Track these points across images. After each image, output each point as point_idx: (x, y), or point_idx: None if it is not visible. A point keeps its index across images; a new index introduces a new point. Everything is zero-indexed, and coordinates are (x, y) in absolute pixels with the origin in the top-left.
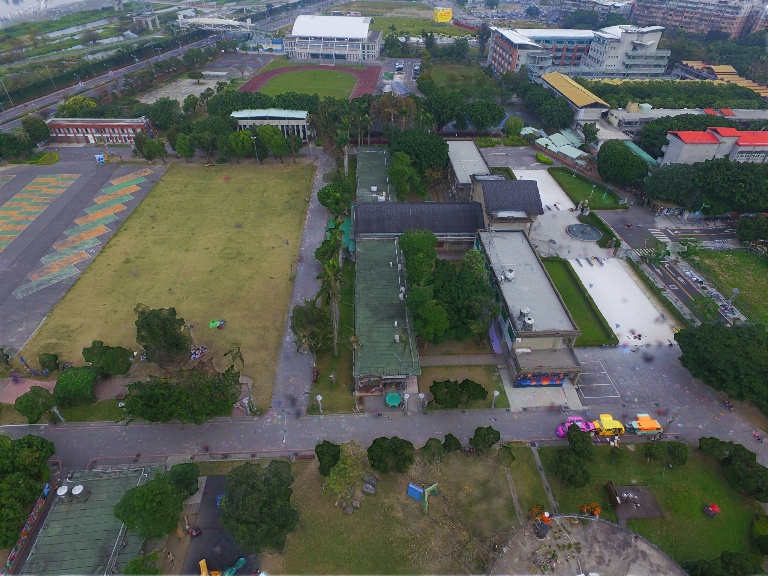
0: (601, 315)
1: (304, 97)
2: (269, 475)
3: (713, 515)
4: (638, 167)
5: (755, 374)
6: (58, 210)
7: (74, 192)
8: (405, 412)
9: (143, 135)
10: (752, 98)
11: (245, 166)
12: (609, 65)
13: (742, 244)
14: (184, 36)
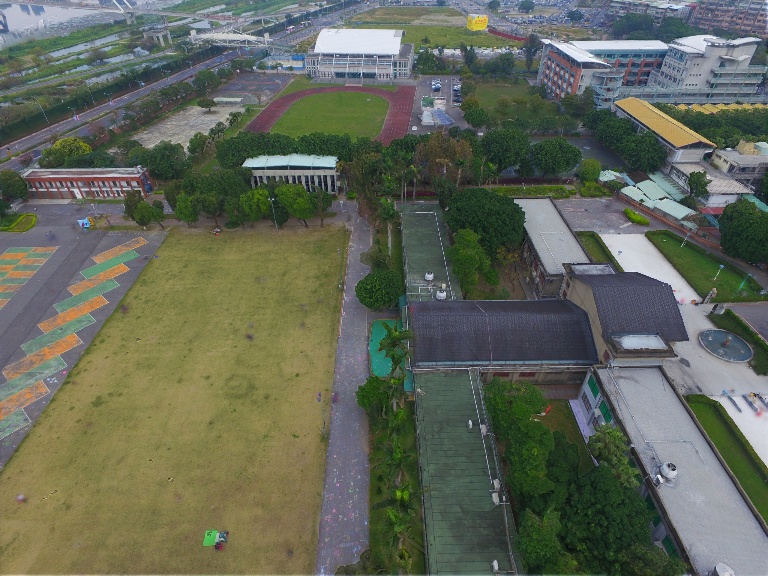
0: None
1: (333, 139)
2: None
3: None
4: None
5: None
6: (20, 307)
7: (46, 276)
8: None
9: (136, 194)
10: None
11: (261, 232)
12: (690, 84)
13: None
14: (196, 54)
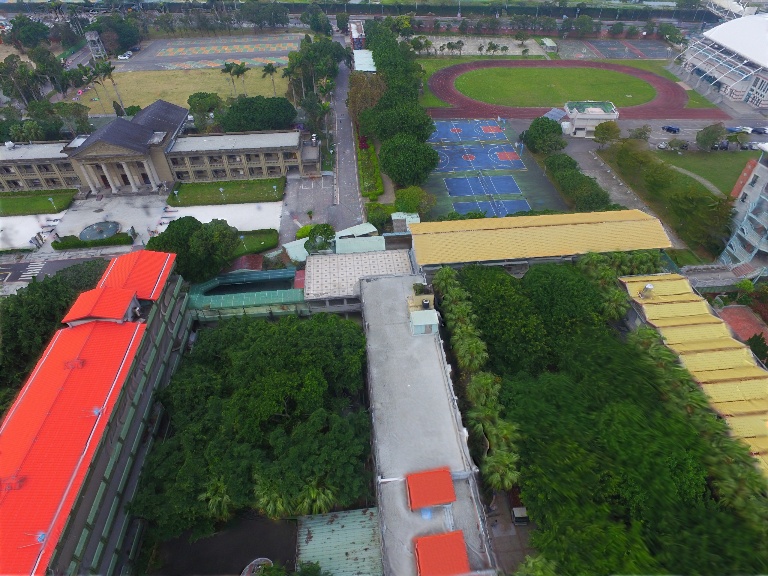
0: None
1: (386, 57)
2: None
3: None
4: None
5: None
6: (245, 54)
7: None
8: None
9: None
10: None
11: None
12: None
13: None
14: None
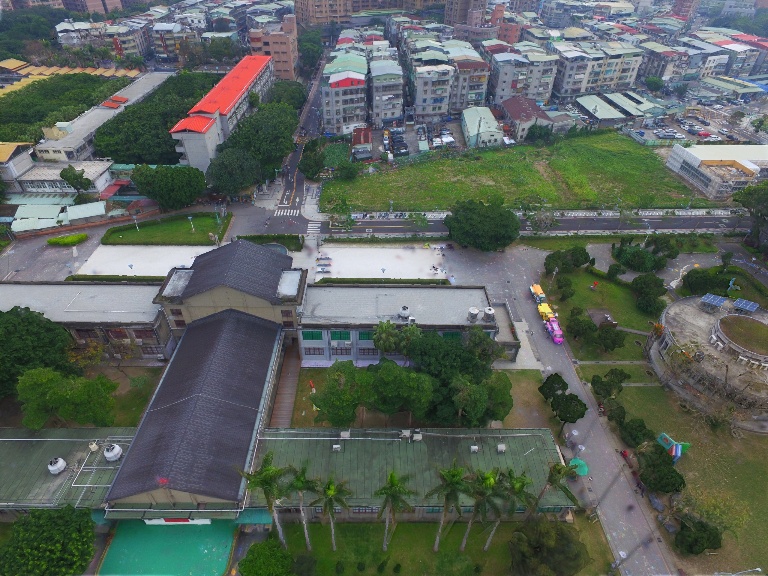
0: (413, 279)
1: None
2: None
3: None
4: (200, 176)
5: None
6: None
7: None
8: None
9: None
10: (97, 80)
11: None
12: None
13: (315, 180)
14: None
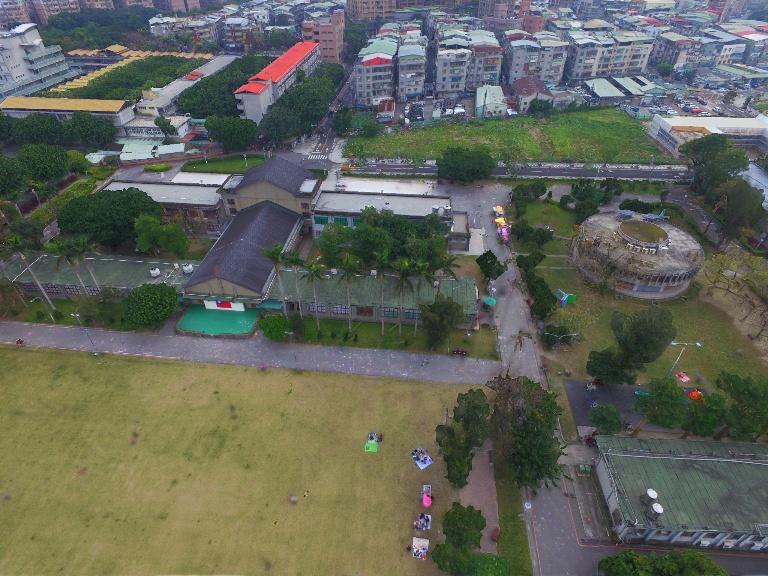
0: None
1: None
2: (633, 315)
3: None
4: (254, 125)
5: None
6: None
7: None
8: None
9: None
10: (180, 61)
11: None
12: (18, 76)
13: (343, 136)
14: None
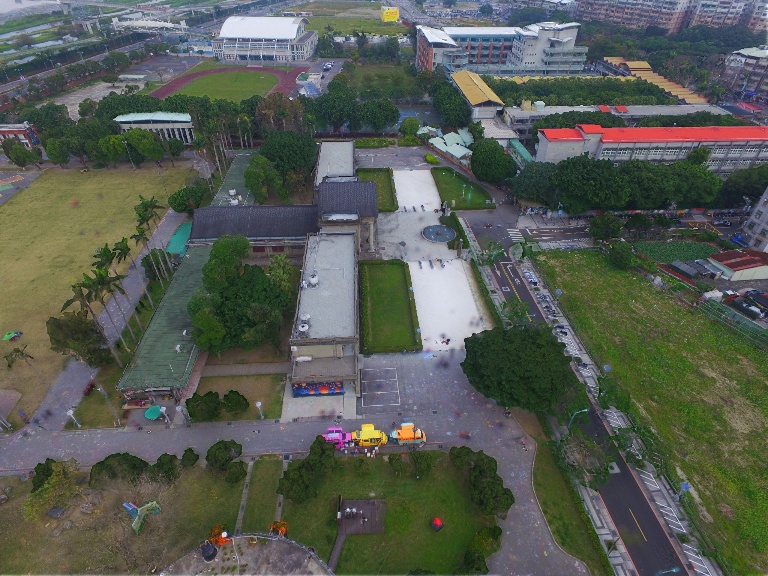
0: (416, 319)
1: (192, 100)
2: None
3: (439, 529)
4: (505, 166)
5: (519, 380)
6: None
7: None
8: (168, 425)
9: (16, 141)
10: (655, 94)
11: (121, 171)
12: (528, 63)
13: (595, 243)
14: (116, 39)
